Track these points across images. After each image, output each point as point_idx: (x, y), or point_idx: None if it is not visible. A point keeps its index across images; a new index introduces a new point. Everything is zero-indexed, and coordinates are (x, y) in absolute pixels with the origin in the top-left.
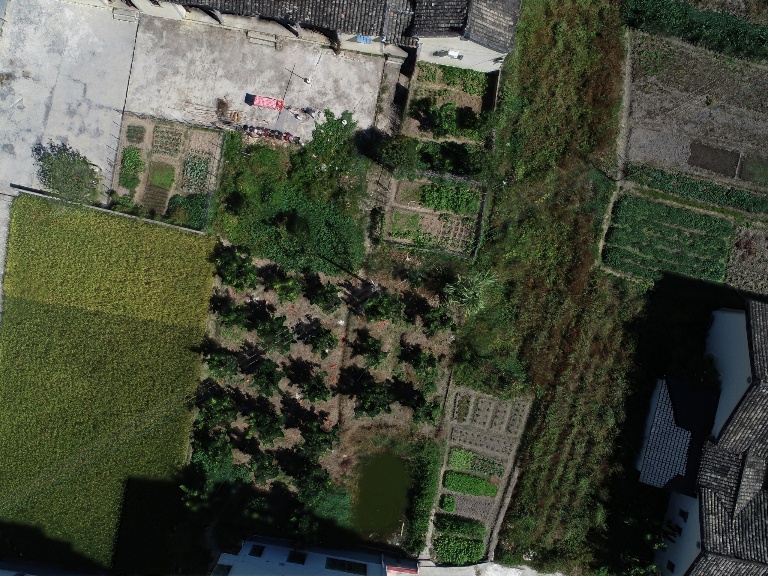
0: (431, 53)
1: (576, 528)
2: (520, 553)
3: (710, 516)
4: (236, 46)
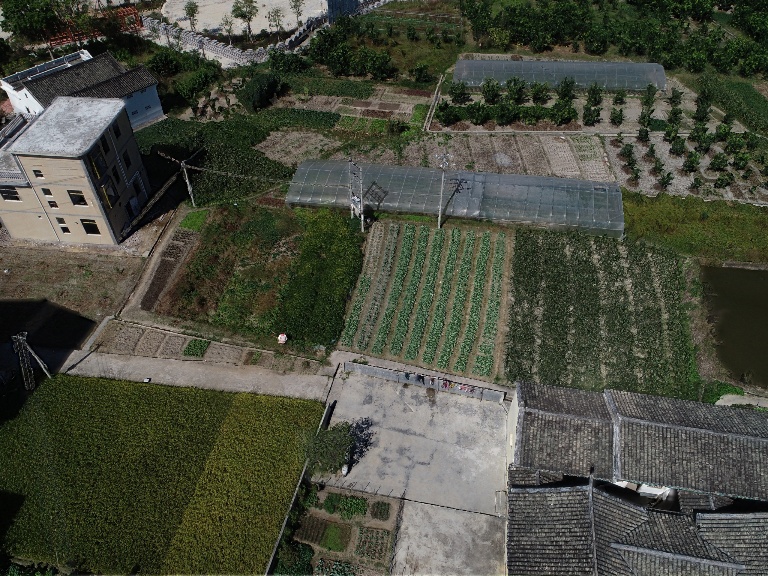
0: None
1: None
2: None
3: None
4: None
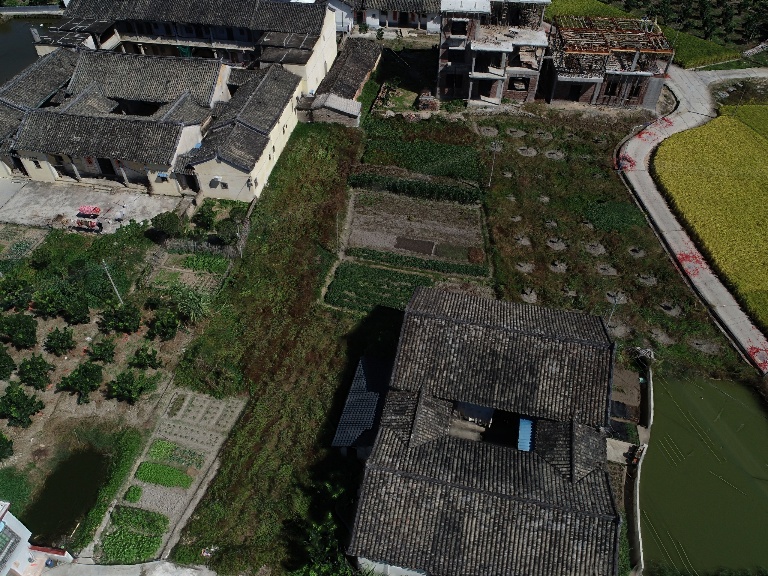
0: (208, 185)
1: (270, 518)
2: (199, 547)
3: (383, 444)
4: (84, 193)
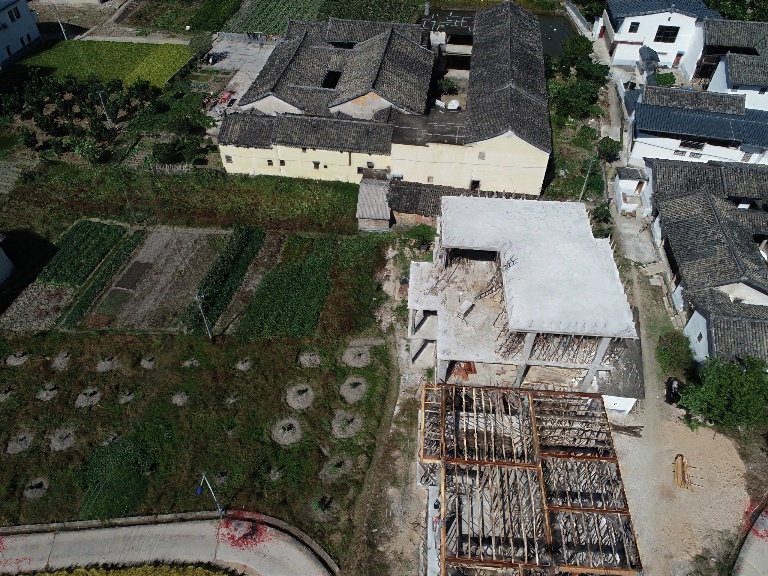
0: None
1: None
2: None
3: None
4: None
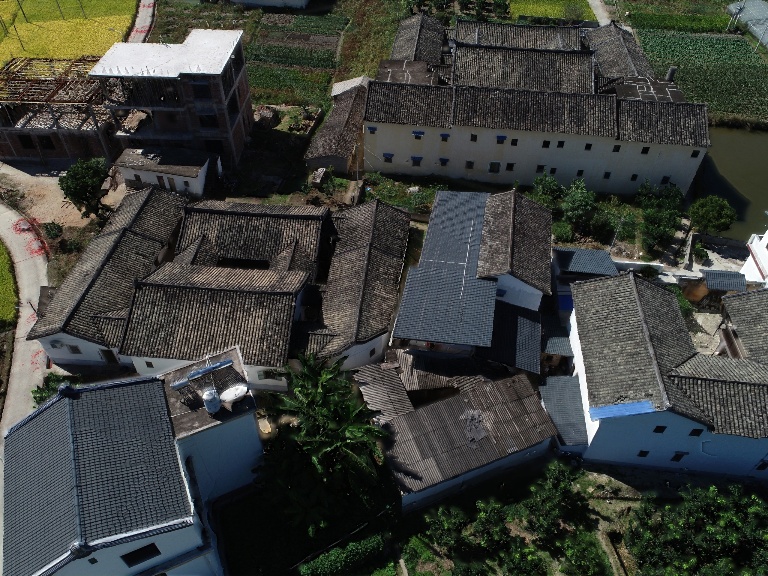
0: None
1: None
2: None
3: None
4: None
